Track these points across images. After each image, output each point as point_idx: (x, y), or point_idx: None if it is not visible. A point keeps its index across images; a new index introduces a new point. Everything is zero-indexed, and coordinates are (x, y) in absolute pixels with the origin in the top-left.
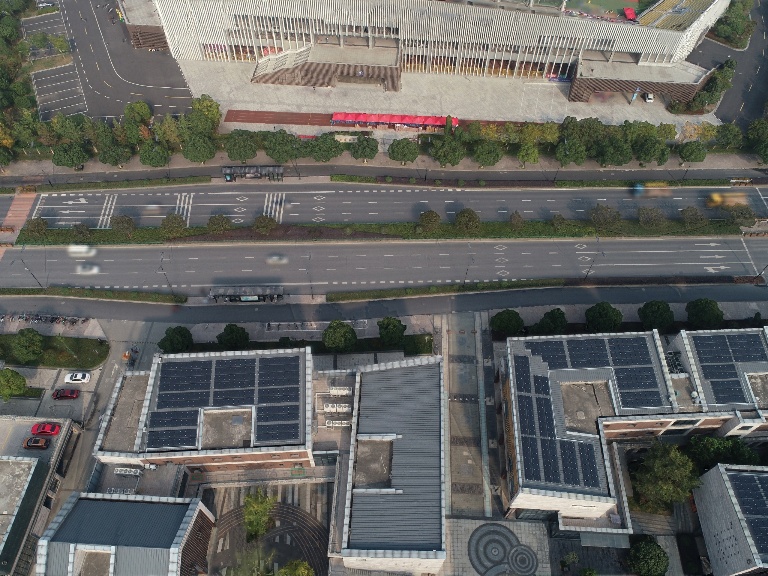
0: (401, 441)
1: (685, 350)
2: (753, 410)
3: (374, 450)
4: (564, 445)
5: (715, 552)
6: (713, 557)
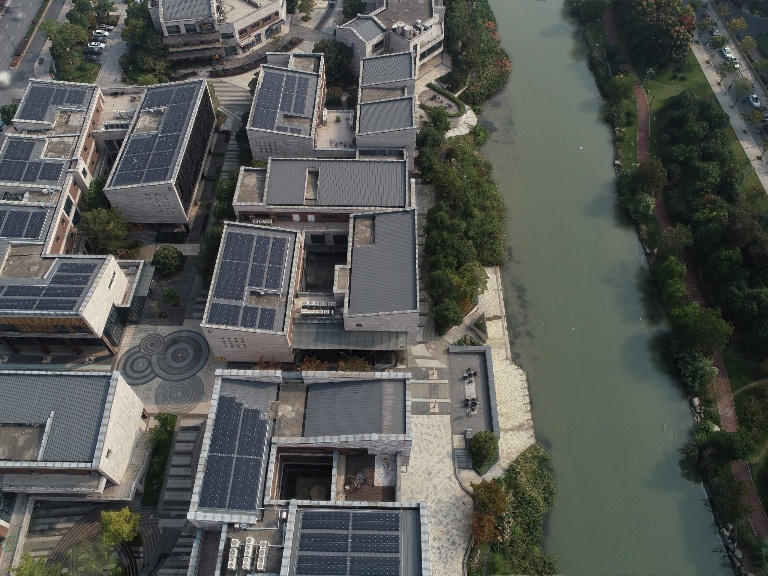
0: (2, 413)
1: (4, 187)
2: (71, 162)
3: (4, 442)
4: (54, 281)
5: (168, 216)
6: (172, 219)
